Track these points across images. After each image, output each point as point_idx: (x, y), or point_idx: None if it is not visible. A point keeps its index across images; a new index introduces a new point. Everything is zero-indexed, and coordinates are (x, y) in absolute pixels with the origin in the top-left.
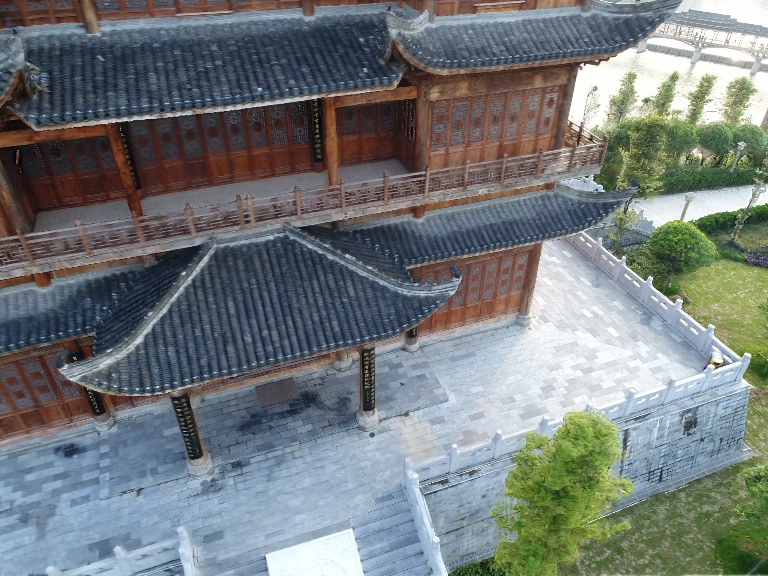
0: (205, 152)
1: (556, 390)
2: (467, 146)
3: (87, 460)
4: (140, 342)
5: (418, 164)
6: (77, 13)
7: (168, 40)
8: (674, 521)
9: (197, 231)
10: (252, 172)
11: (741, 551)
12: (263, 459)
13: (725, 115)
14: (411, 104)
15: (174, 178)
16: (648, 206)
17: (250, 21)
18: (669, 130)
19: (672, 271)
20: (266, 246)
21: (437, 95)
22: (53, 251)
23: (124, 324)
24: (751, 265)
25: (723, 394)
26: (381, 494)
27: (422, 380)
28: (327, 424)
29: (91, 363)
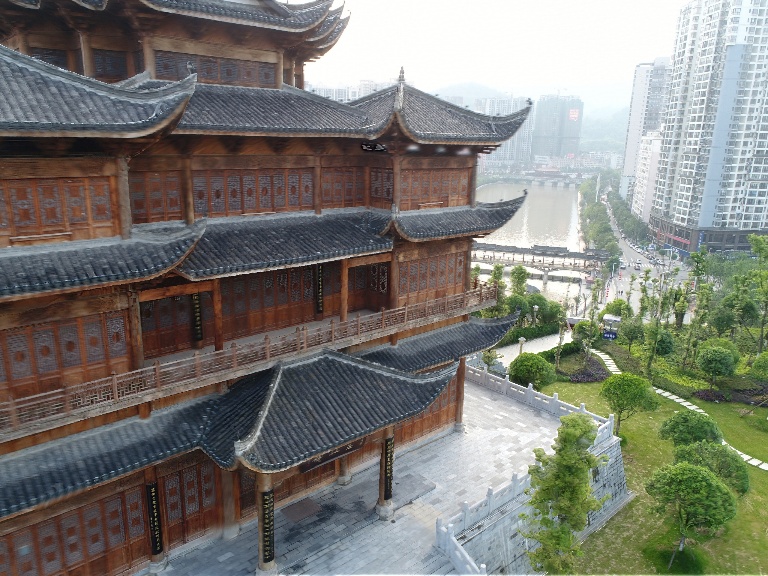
0: (247, 309)
1: (505, 465)
2: (418, 292)
3: None
4: (259, 434)
5: (393, 305)
6: (182, 214)
7: (242, 229)
8: (611, 547)
9: (270, 357)
10: (276, 323)
11: (660, 551)
12: (316, 558)
13: (515, 292)
14: (382, 267)
15: (224, 331)
16: None
17: (285, 218)
18: None
19: None
20: (314, 365)
21: (402, 258)
22: (175, 378)
23: (228, 432)
24: (575, 383)
25: (607, 446)
26: (423, 556)
27: (410, 478)
28: (355, 521)
29: (244, 443)
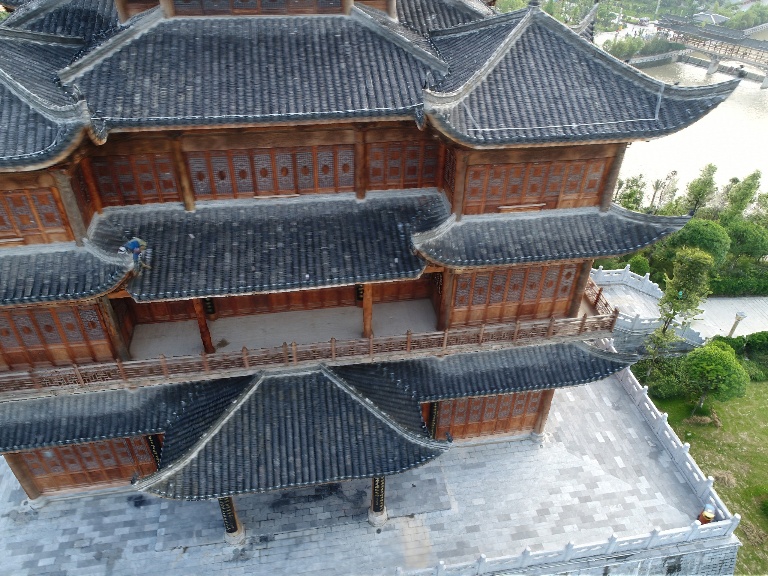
0: None
1: (550, 515)
2: (488, 305)
3: (150, 513)
4: (194, 457)
5: (442, 318)
6: (179, 196)
7: (245, 219)
8: None
9: (250, 365)
10: (305, 304)
11: None
12: (286, 538)
13: None
14: None
15: (242, 306)
16: (704, 309)
17: (312, 202)
18: (739, 233)
19: (705, 393)
20: (304, 380)
21: (462, 270)
22: (141, 373)
23: (186, 432)
24: None
25: (709, 547)
26: None
27: (432, 485)
28: (343, 514)
29: (156, 477)
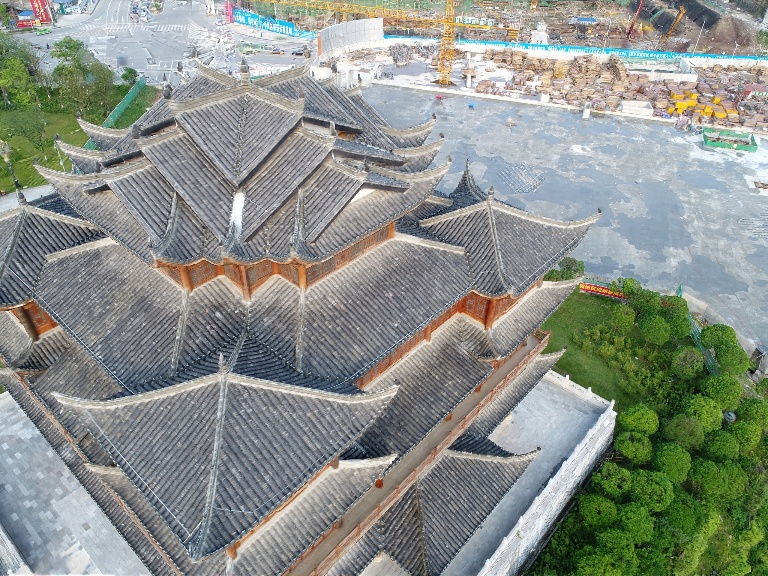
0: None
1: None
2: None
3: None
4: None
5: None
6: None
7: None
8: None
9: None
10: None
11: None
12: None
13: None
14: None
15: None
16: None
17: None
18: None
19: None
20: None
21: None
22: None
23: None
24: None
25: None
26: None
27: None
28: None
29: None
